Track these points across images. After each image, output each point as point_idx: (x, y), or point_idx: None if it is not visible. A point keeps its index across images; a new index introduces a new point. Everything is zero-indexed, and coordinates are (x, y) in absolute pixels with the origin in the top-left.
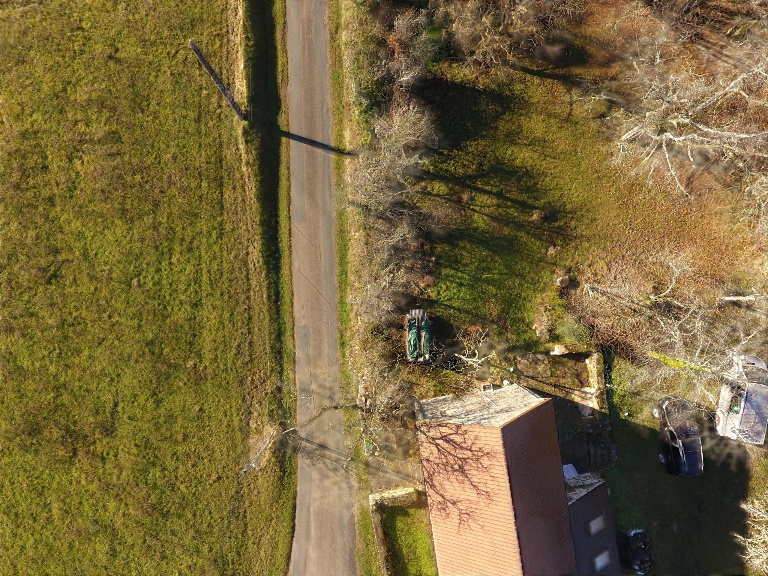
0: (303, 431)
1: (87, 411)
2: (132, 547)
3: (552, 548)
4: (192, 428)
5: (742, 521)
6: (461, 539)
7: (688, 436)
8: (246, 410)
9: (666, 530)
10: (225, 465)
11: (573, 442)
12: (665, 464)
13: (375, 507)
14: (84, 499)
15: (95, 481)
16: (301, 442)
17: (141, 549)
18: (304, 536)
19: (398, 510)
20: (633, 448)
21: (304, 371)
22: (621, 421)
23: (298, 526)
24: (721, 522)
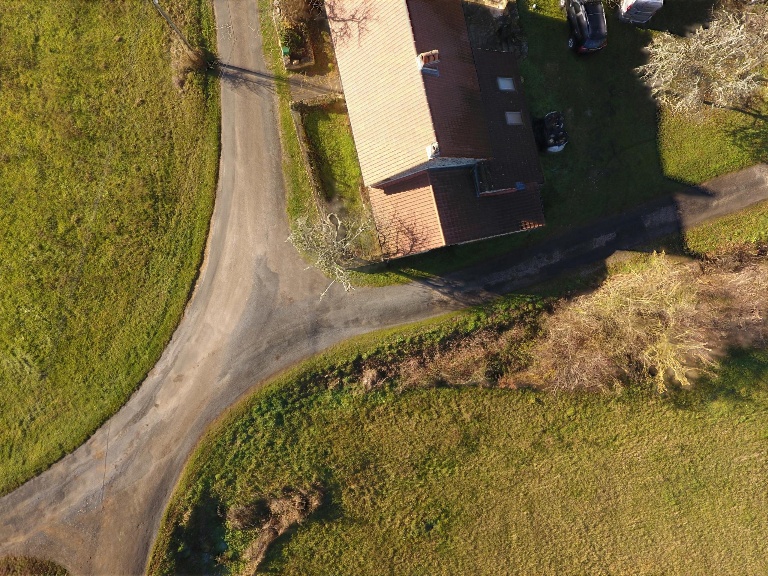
0: (224, 58)
1: (9, 46)
2: (61, 170)
3: (450, 50)
4: (114, 57)
5: (653, 101)
6: (362, 50)
7: (590, 1)
8: (166, 38)
9: (580, 115)
10: (148, 89)
11: (487, 45)
12: (574, 45)
13: (294, 102)
14: (11, 128)
15: (20, 111)
16: (223, 68)
17: (70, 171)
18: (230, 153)
19: (319, 115)
20: (543, 39)
21: (222, 3)
22: (530, 14)
23: (224, 145)
24: (633, 104)
